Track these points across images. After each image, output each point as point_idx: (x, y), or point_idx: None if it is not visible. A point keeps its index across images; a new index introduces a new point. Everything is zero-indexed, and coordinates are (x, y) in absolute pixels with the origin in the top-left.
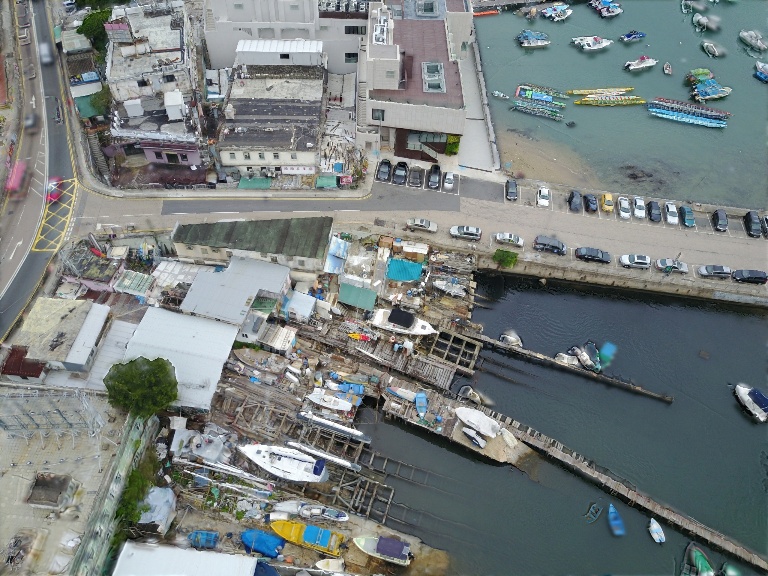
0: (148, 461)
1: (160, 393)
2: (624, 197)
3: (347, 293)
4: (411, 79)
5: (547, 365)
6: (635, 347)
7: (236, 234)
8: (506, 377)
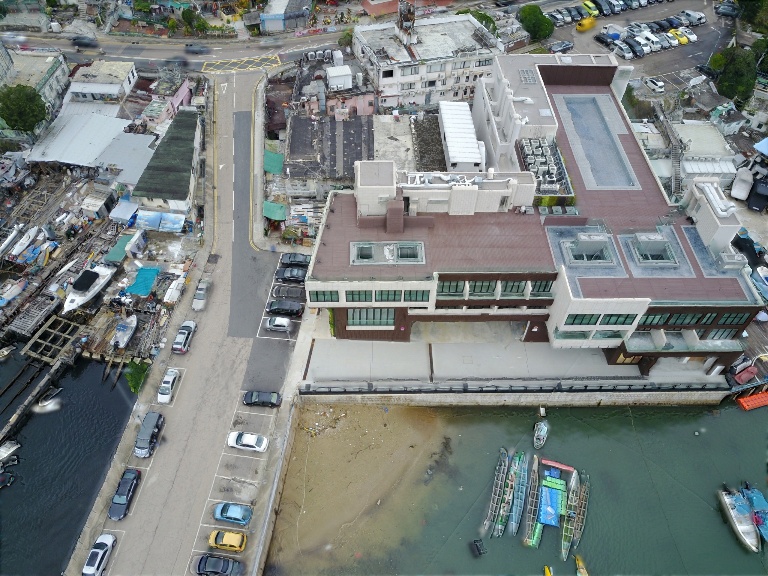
0: (3, 143)
1: (3, 111)
2: (232, 569)
3: (128, 240)
4: (383, 232)
5: (2, 425)
6: (0, 551)
7: (177, 142)
8: (8, 385)
